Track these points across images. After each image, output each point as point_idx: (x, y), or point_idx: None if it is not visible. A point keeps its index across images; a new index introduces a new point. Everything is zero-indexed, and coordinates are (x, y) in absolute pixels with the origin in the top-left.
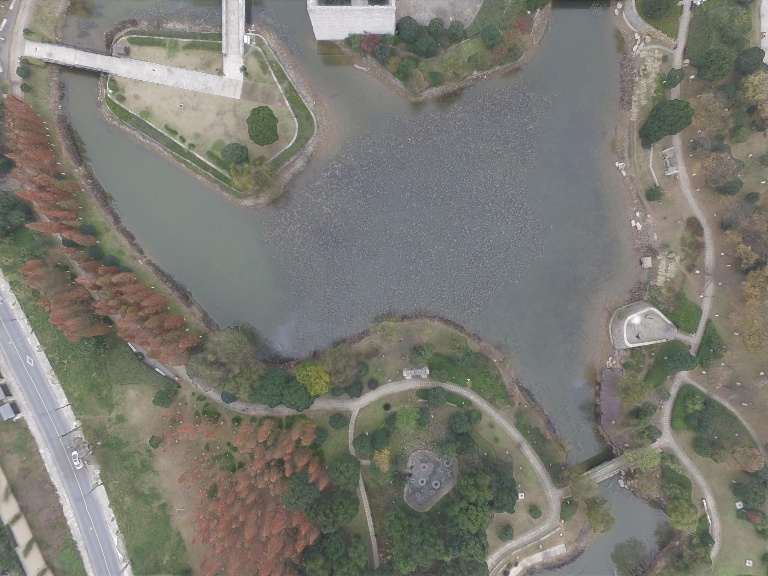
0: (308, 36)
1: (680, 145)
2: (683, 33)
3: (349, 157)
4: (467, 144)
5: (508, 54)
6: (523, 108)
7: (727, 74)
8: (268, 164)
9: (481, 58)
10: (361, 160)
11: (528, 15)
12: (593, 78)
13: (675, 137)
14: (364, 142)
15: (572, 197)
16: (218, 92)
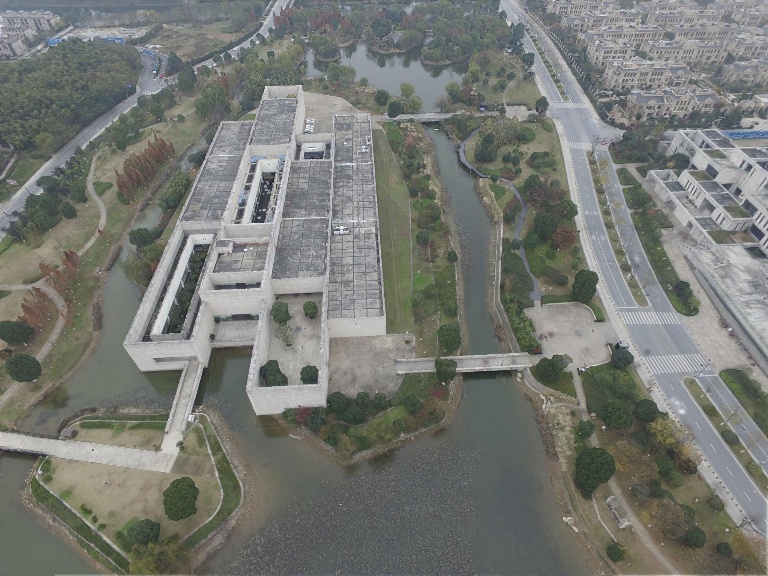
0: (250, 412)
1: (621, 493)
2: (580, 392)
3: (274, 529)
4: (401, 506)
5: (430, 417)
6: (453, 465)
7: (630, 422)
8: (177, 542)
9: (405, 422)
10: (287, 532)
11: (443, 386)
12: (514, 434)
13: (612, 485)
14: (292, 511)
15: (527, 563)
16: (149, 467)
